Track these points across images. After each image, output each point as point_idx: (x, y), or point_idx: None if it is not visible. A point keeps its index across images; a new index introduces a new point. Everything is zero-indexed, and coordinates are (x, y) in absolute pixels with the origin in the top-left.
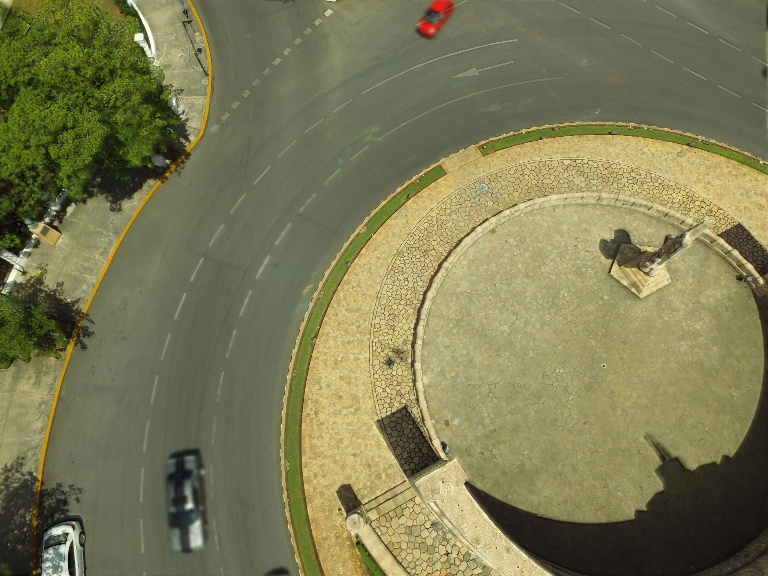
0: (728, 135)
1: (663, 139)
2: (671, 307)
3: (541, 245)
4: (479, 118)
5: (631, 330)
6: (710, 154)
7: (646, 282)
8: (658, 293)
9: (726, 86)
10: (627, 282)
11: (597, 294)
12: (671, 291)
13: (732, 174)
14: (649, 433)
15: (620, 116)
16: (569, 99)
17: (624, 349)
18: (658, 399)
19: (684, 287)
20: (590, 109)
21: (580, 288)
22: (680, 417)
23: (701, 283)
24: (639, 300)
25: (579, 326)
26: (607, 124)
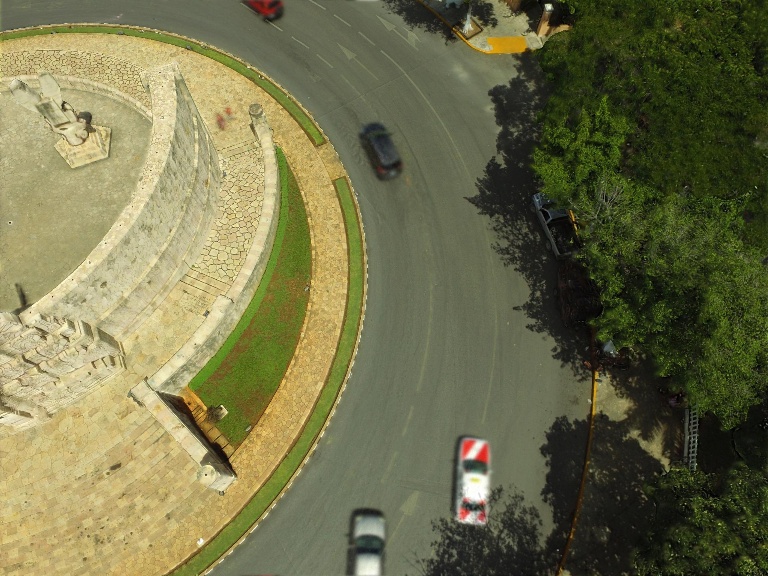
0: (230, 43)
1: (166, 42)
2: (99, 178)
3: (5, 119)
4: (6, 13)
5: (52, 195)
6: (201, 56)
7: (69, 151)
8: (93, 166)
9: (248, 4)
10: (65, 154)
11: (36, 163)
12: (106, 165)
13: (212, 74)
14: (22, 281)
15: (138, 21)
16: (98, 4)
17: (36, 210)
18: (46, 253)
19: (120, 163)
20: (113, 13)
21: (22, 157)
22: (58, 269)
23: (138, 160)
24: (72, 170)
25: (4, 188)
26: (122, 26)
